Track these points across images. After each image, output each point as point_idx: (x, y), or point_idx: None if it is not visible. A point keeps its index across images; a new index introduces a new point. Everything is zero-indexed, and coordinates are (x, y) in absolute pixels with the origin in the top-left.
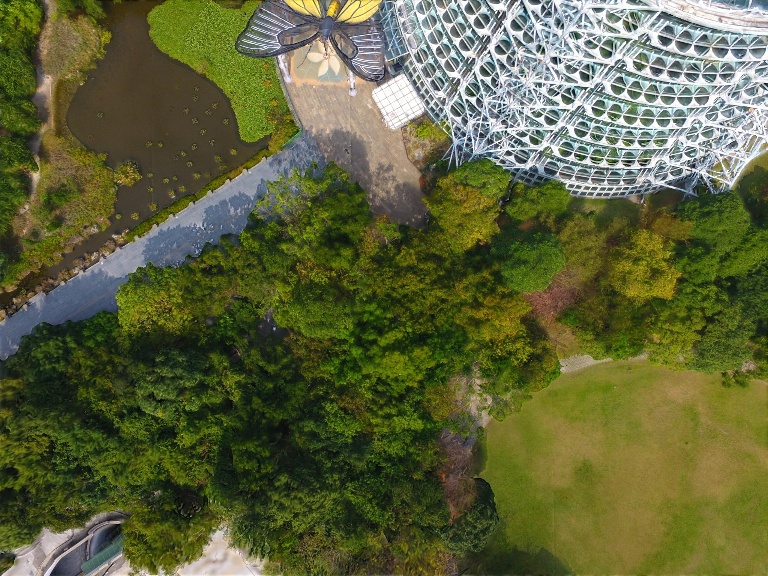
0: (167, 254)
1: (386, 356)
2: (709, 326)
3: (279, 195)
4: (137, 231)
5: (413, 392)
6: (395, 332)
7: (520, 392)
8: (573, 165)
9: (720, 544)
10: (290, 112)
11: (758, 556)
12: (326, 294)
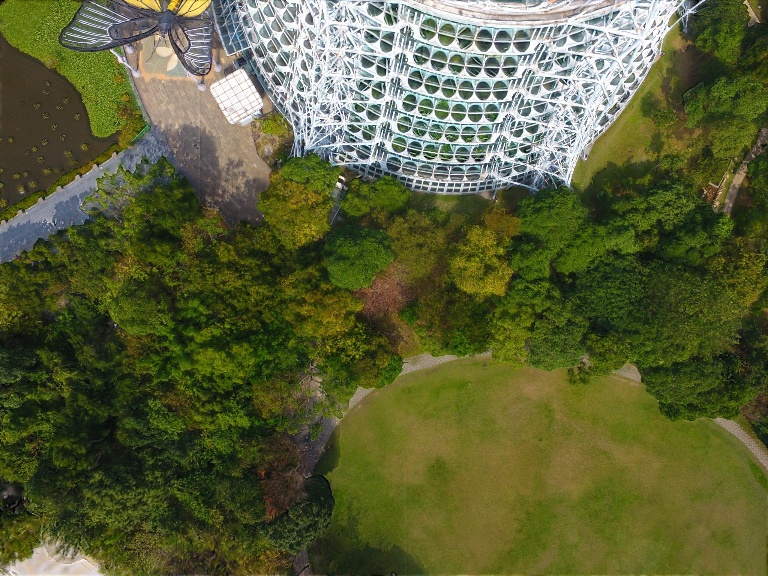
0: (17, 250)
1: (200, 353)
2: (537, 322)
3: (101, 190)
4: None
5: (241, 389)
6: (211, 328)
7: (346, 389)
8: (415, 161)
9: (573, 540)
10: (140, 107)
11: (612, 552)
12: (142, 290)
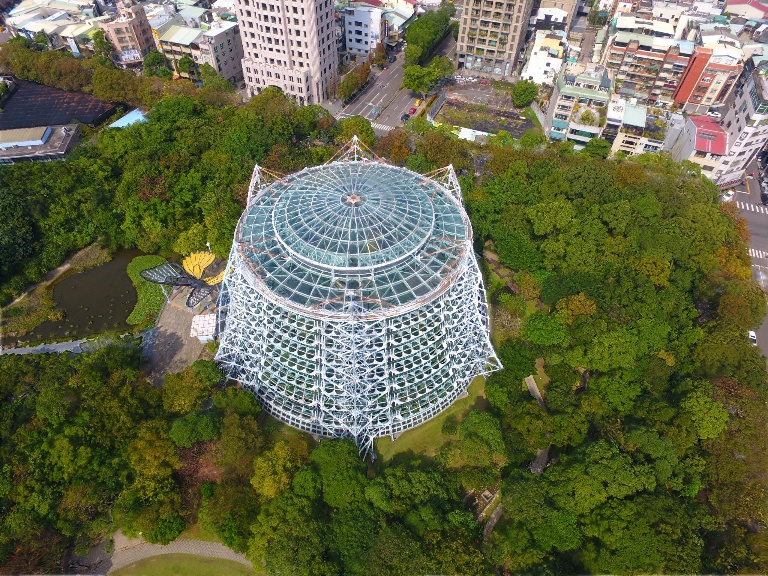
0: None
1: (60, 439)
2: (280, 524)
3: None
4: (32, 343)
5: (63, 485)
6: (79, 428)
7: (124, 515)
8: None
9: None
10: None
11: None
12: None
